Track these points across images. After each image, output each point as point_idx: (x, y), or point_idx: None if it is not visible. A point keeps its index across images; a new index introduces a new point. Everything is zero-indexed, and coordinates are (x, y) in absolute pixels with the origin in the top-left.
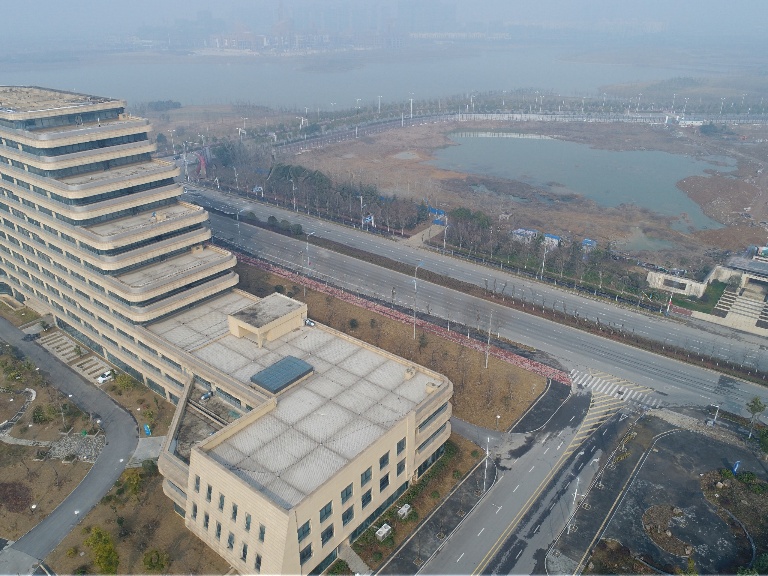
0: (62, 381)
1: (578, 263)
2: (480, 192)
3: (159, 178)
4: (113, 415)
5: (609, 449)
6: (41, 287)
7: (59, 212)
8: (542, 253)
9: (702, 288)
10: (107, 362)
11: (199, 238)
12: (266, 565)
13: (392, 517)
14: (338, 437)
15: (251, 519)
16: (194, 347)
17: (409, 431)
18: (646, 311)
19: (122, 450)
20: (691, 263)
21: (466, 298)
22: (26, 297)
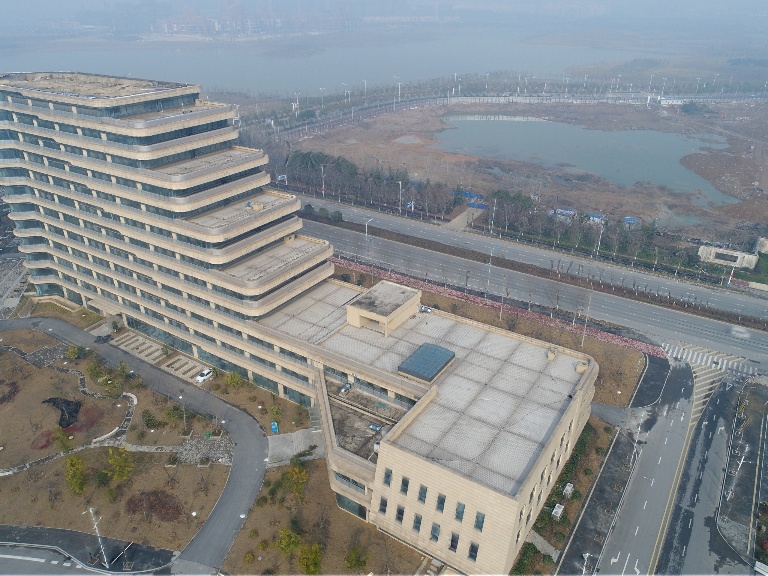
0: (158, 383)
1: (630, 240)
2: (515, 174)
3: (251, 166)
4: (229, 415)
5: (729, 417)
6: (110, 286)
7: (155, 204)
8: (587, 232)
9: (755, 260)
10: (197, 361)
11: (294, 227)
12: (485, 553)
13: (559, 497)
14: (515, 421)
15: (465, 508)
16: (320, 339)
17: (577, 411)
18: (707, 284)
19: (255, 450)
20: (730, 236)
21: (532, 279)
22: (84, 297)
